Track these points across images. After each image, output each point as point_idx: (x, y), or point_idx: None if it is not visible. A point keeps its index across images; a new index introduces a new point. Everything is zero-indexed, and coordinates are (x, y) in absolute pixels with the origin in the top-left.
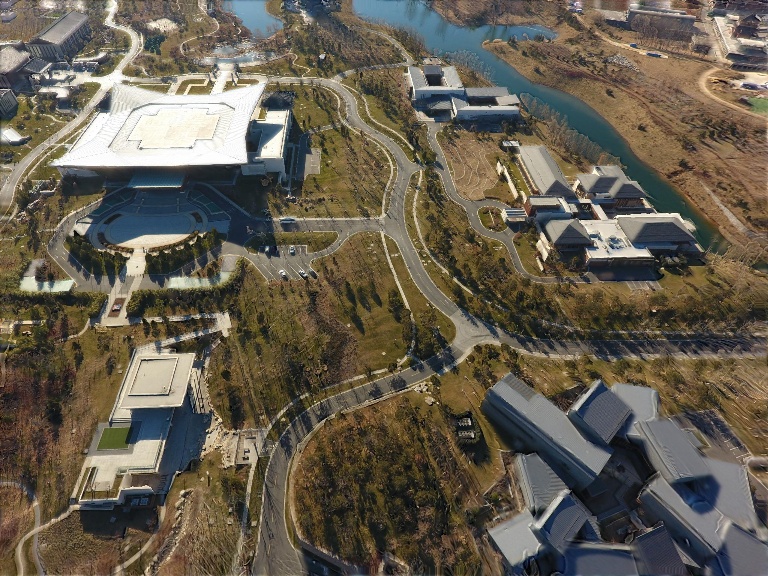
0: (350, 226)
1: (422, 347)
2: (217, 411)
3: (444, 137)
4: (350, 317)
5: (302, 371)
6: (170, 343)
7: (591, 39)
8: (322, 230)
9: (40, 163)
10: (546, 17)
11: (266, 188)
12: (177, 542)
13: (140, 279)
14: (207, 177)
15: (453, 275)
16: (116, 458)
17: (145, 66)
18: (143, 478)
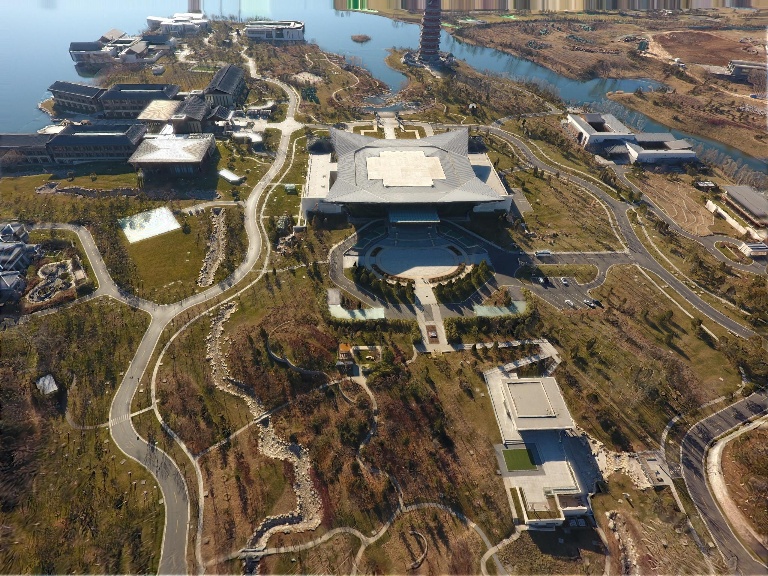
0: (603, 259)
1: (760, 373)
2: (591, 434)
3: (634, 178)
4: (666, 344)
5: (659, 395)
6: (512, 368)
7: (709, 91)
8: (579, 263)
9: (267, 201)
10: (652, 71)
11: (504, 224)
12: (635, 564)
13: (437, 308)
14: (446, 213)
15: (741, 305)
16: (534, 479)
17: (313, 114)
18: (562, 499)
